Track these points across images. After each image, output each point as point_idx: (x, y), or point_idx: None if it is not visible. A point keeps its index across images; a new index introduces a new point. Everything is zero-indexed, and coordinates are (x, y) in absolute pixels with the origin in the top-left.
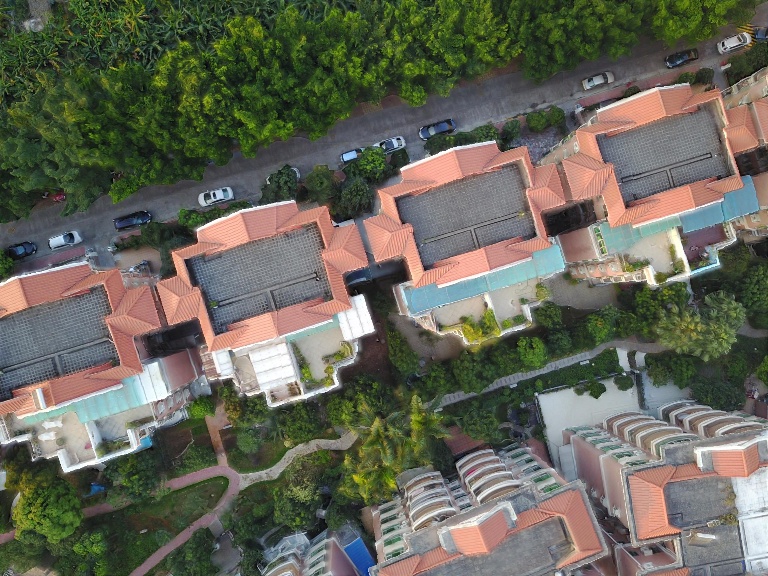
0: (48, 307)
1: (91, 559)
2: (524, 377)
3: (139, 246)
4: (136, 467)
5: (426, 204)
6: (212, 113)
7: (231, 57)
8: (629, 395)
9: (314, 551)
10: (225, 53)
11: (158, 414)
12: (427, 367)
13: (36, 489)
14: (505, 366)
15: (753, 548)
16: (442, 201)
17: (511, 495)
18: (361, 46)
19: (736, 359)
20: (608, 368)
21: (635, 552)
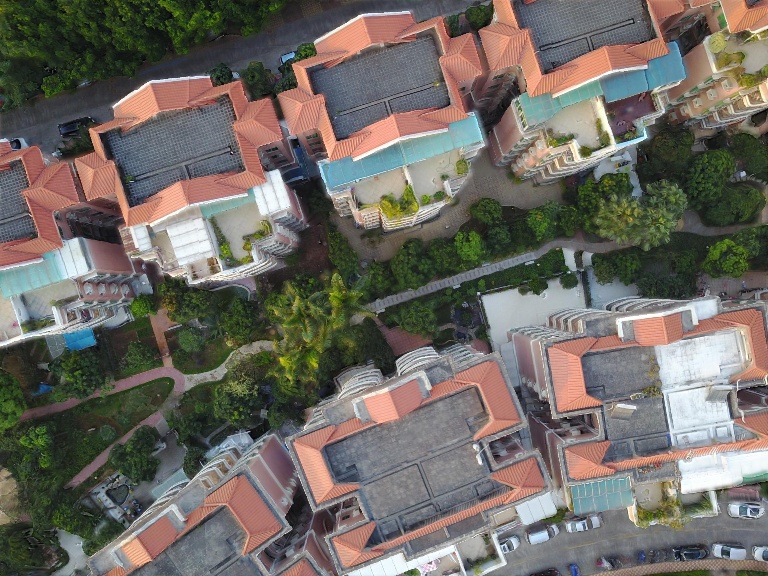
0: None
1: (37, 451)
2: (468, 278)
3: (80, 148)
4: (80, 363)
5: (339, 77)
6: (137, 2)
7: None
8: (576, 295)
9: None
10: None
11: (84, 294)
12: None
13: None
14: (442, 260)
15: (679, 422)
16: (356, 73)
17: (427, 366)
18: None
19: (684, 255)
20: (553, 268)
21: (564, 434)
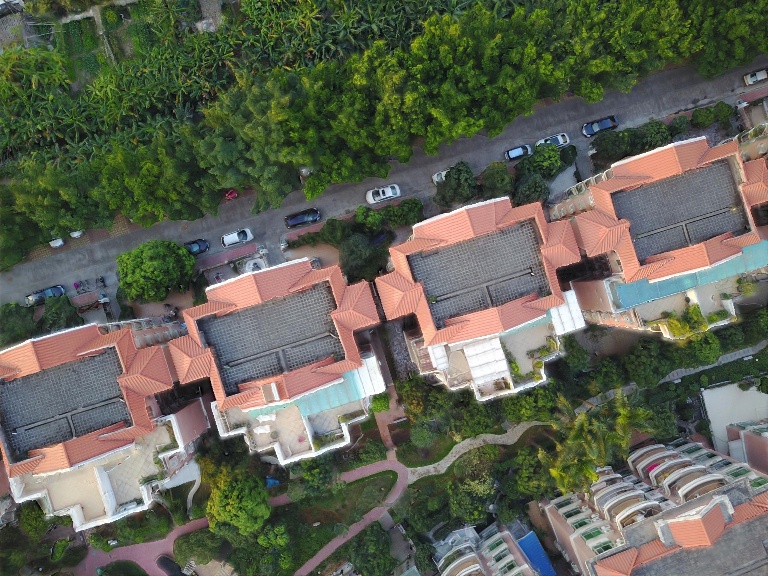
0: (272, 302)
1: (275, 551)
2: (687, 372)
3: (315, 243)
4: (315, 461)
5: (638, 200)
6: (408, 111)
7: (425, 55)
8: None
9: (490, 544)
10: (420, 51)
11: (367, 408)
12: (592, 362)
13: (231, 482)
14: (680, 361)
15: None
16: (654, 197)
17: (725, 489)
18: (544, 43)
19: None
20: None
21: None
